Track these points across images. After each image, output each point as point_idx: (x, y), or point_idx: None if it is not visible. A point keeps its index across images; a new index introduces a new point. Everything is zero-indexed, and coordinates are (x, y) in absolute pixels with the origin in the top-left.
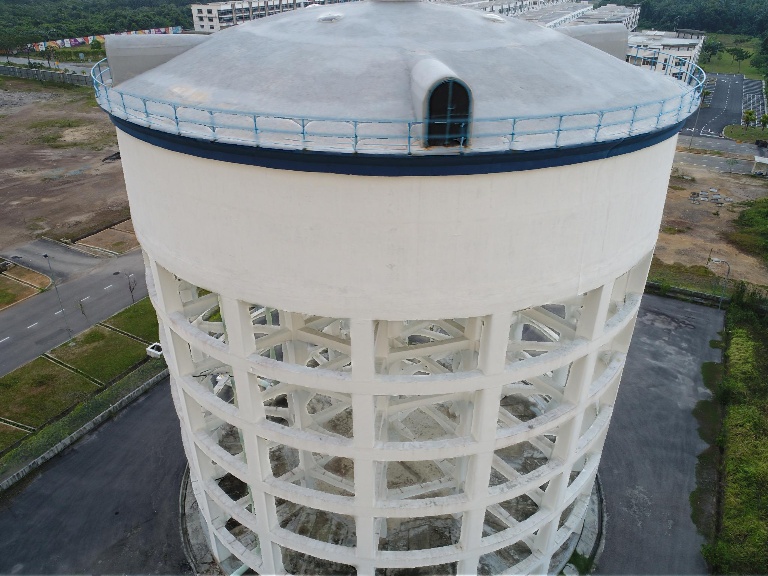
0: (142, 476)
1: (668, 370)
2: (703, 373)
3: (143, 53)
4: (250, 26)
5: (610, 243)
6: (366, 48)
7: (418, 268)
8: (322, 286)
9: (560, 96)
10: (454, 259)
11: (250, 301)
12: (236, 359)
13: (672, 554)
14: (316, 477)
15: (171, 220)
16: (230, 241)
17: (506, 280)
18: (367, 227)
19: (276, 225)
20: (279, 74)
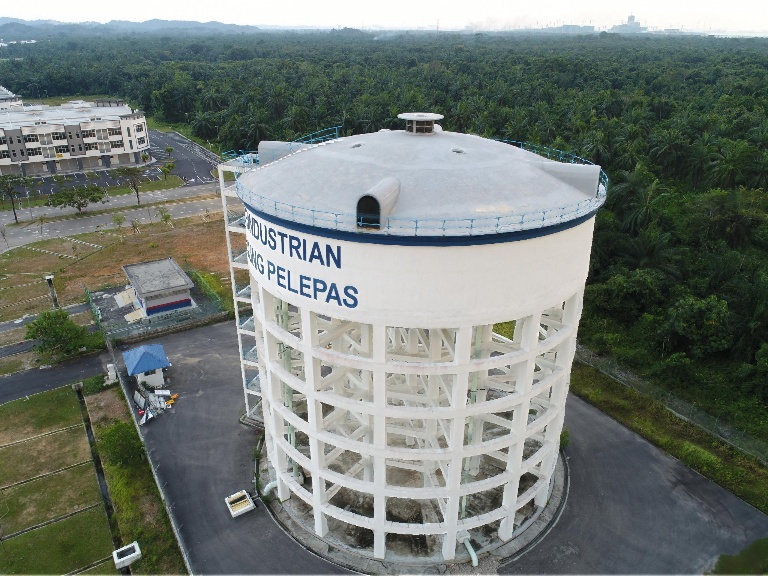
0: None
1: None
2: None
3: (390, 199)
4: (409, 165)
5: None
6: (512, 163)
7: None
8: None
9: None
10: None
11: None
12: (532, 352)
13: None
14: None
15: (506, 286)
16: (546, 277)
17: None
18: None
19: (566, 257)
20: (516, 185)
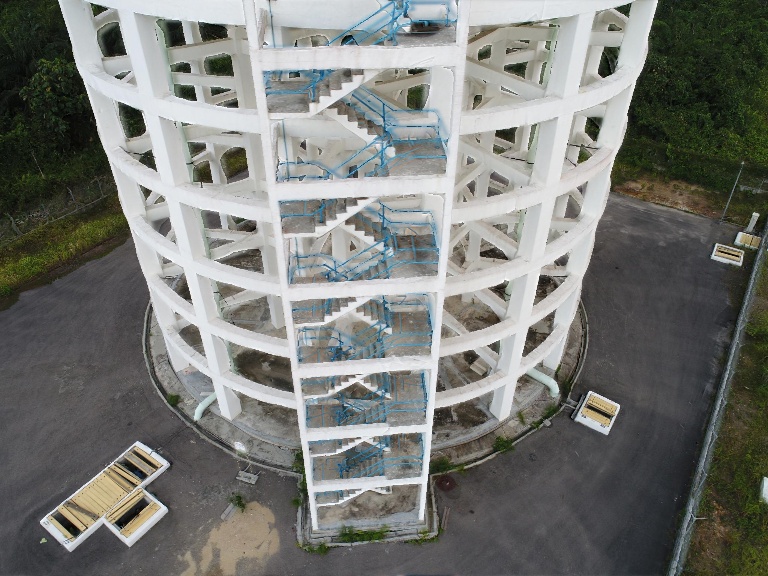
0: (620, 293)
1: None
2: None
3: None
4: None
5: None
6: None
7: None
8: None
9: None
10: None
11: None
12: None
13: (168, 226)
14: None
15: None
16: None
17: None
18: None
19: None
20: None
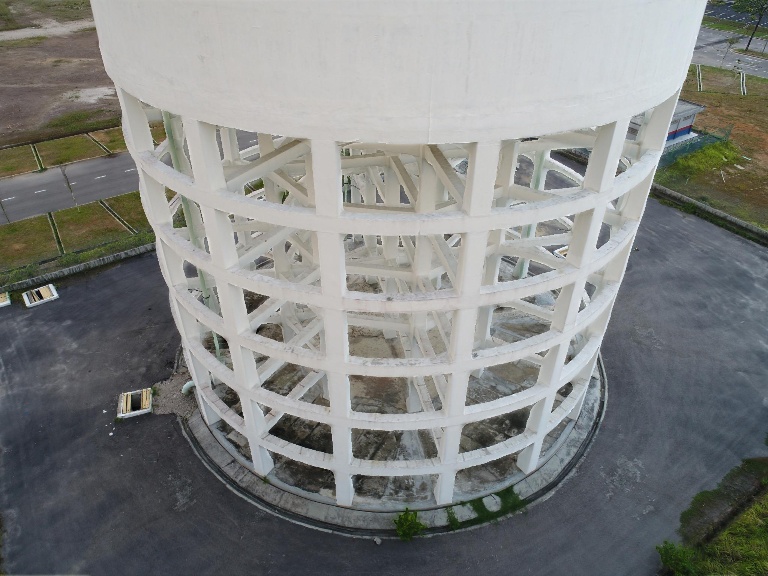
0: None
1: None
2: None
3: None
4: None
5: (481, 84)
6: None
7: (225, 64)
8: (157, 75)
9: None
10: (258, 58)
11: (125, 89)
12: (134, 153)
13: (626, 537)
14: (290, 326)
15: None
16: (103, 20)
17: (322, 98)
18: (175, 7)
19: (118, 1)
20: None
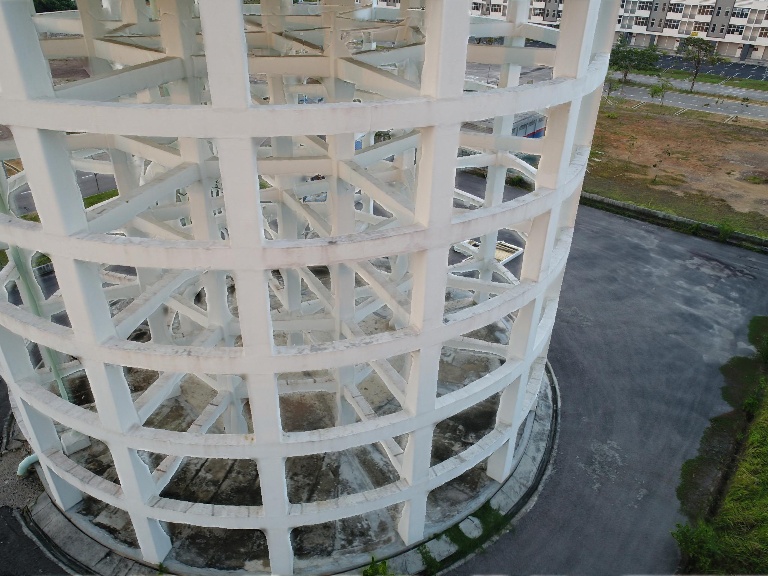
0: None
1: (702, 318)
2: (751, 327)
3: None
4: None
5: None
6: None
7: None
8: None
9: None
10: None
11: None
12: None
13: (631, 531)
14: None
15: None
16: None
17: None
18: None
19: None
20: None
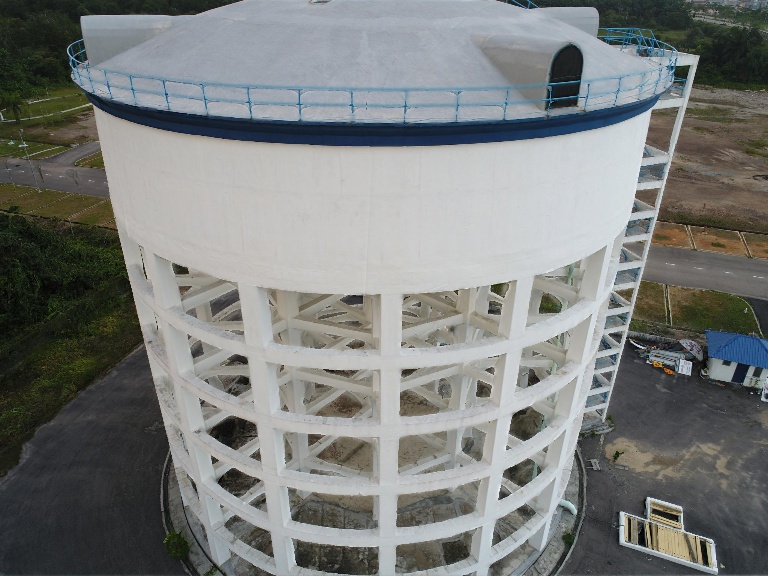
0: None
1: None
2: None
3: None
4: None
5: (136, 206)
6: None
7: None
8: None
9: (152, 58)
10: None
11: None
12: None
13: None
14: None
15: None
16: None
17: None
18: None
19: None
20: None
